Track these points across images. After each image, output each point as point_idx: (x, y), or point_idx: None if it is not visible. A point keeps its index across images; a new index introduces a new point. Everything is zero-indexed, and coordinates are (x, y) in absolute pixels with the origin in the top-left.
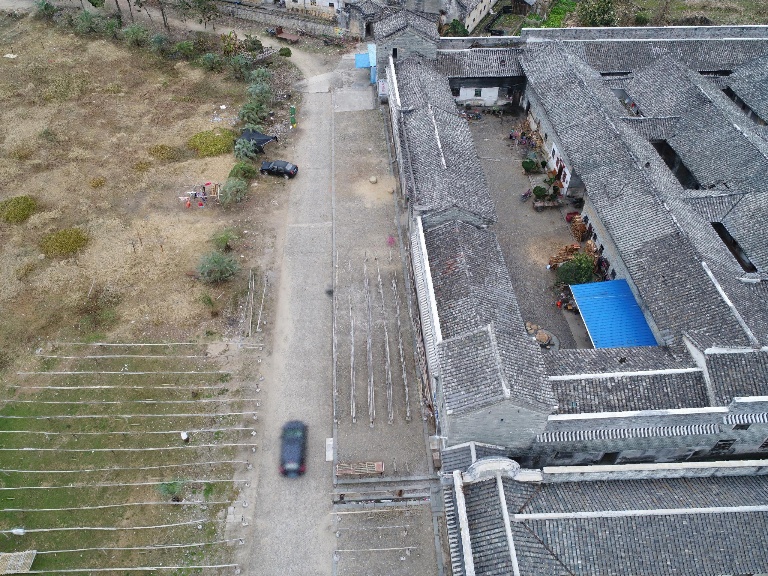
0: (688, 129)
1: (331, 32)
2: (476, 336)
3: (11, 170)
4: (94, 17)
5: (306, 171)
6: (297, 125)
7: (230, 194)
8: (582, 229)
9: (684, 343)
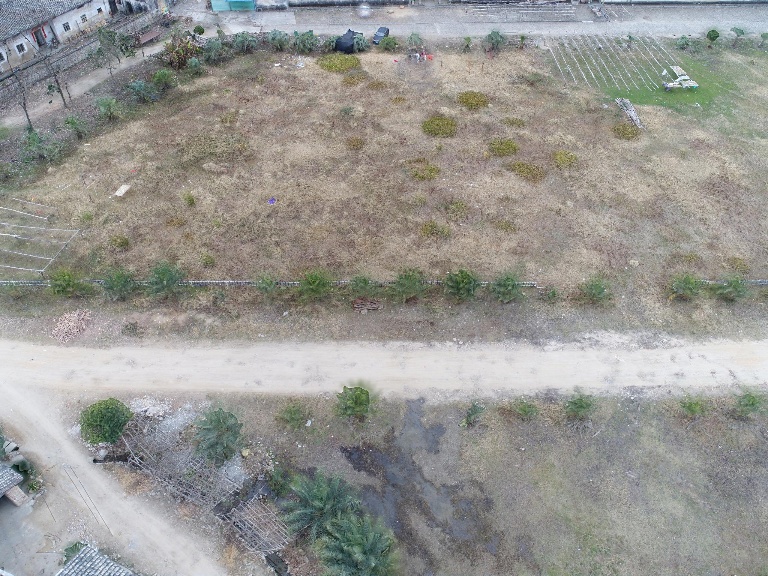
0: None
1: (146, 21)
2: None
3: (385, 138)
4: None
5: None
6: None
7: None
8: None
9: None
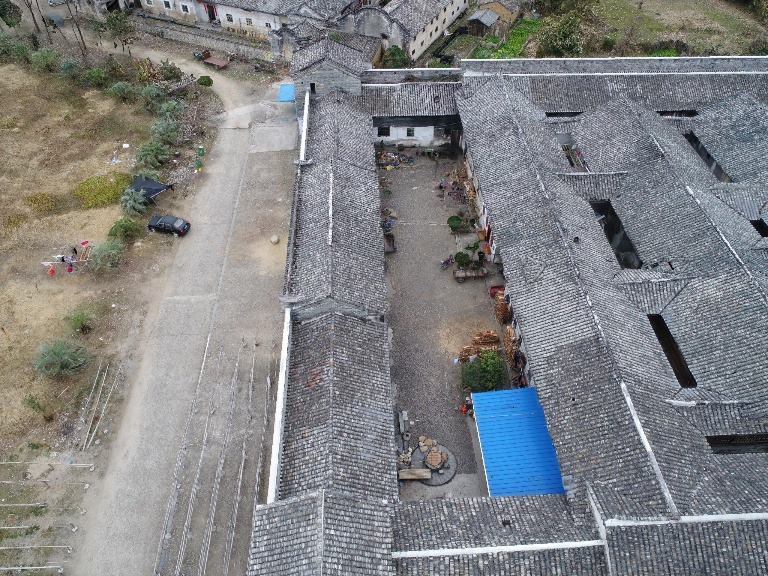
0: (635, 189)
1: (264, 56)
2: (302, 504)
3: None
4: (11, 37)
5: (201, 227)
6: (203, 169)
7: (100, 259)
8: (503, 310)
9: (588, 498)
